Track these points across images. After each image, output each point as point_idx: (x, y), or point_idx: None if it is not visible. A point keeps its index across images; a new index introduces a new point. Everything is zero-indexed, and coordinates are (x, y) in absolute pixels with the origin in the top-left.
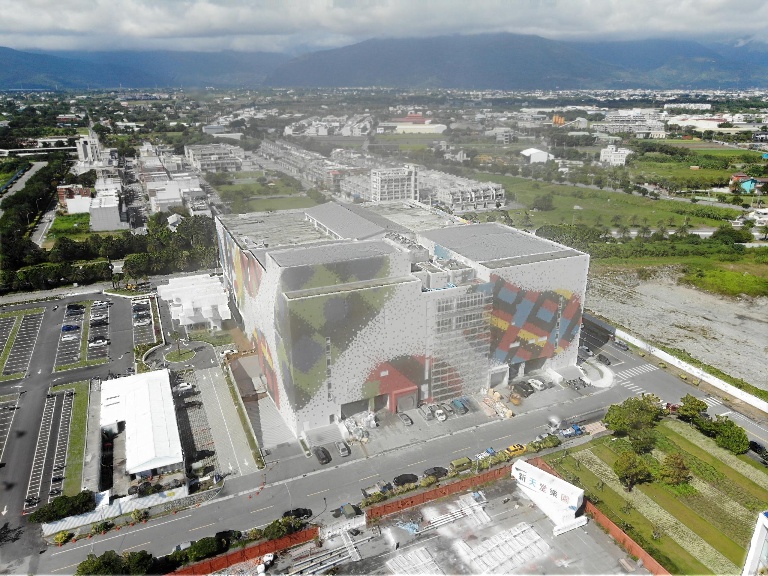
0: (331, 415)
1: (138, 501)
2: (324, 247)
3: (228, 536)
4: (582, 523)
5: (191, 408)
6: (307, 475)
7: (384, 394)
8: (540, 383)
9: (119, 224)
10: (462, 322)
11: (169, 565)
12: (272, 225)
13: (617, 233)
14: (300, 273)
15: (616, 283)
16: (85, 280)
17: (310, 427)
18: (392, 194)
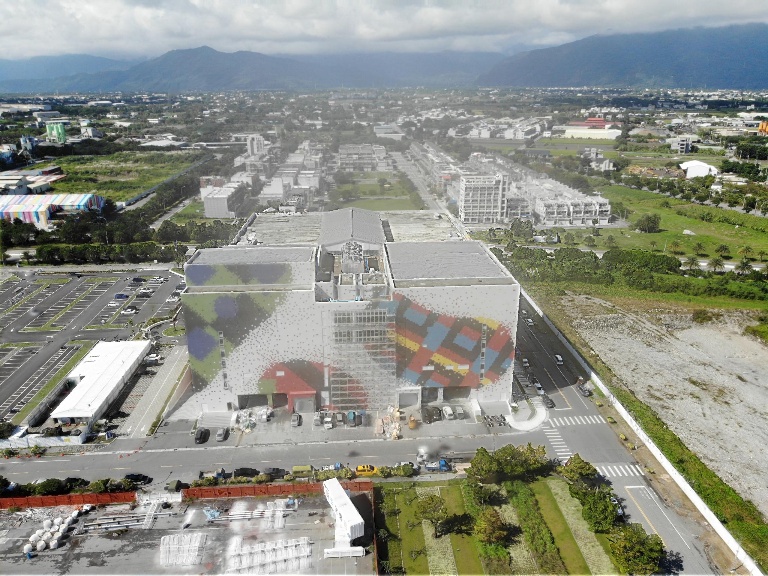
0: (229, 403)
1: (41, 439)
2: (251, 250)
3: (74, 482)
4: (358, 553)
5: (145, 376)
6: (177, 450)
7: (284, 393)
8: (449, 412)
9: (227, 213)
10: (363, 336)
11: (23, 493)
12: (290, 225)
13: (707, 266)
14: (203, 271)
15: (653, 322)
16: (164, 258)
17: (209, 410)
18: (477, 202)
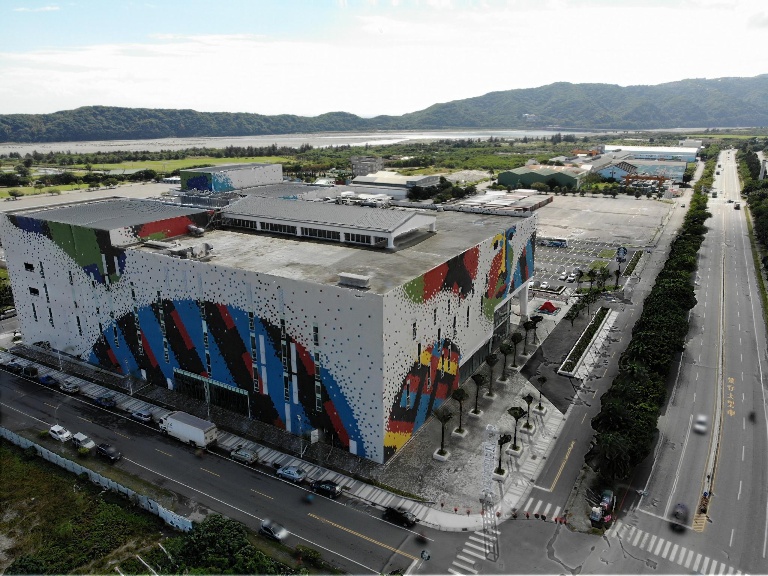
0: None
1: None
2: None
3: None
4: None
5: None
6: None
7: None
8: None
9: None
10: None
11: None
12: None
13: None
14: None
15: None
16: None
17: None
18: None
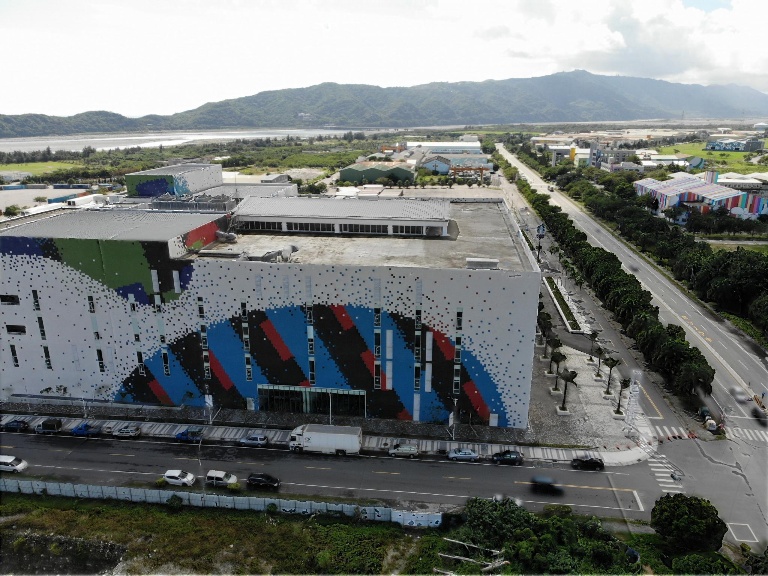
0: None
1: None
2: None
3: None
4: None
5: None
6: None
7: None
8: None
9: None
10: None
11: None
12: None
13: None
14: None
15: None
16: None
17: None
18: None
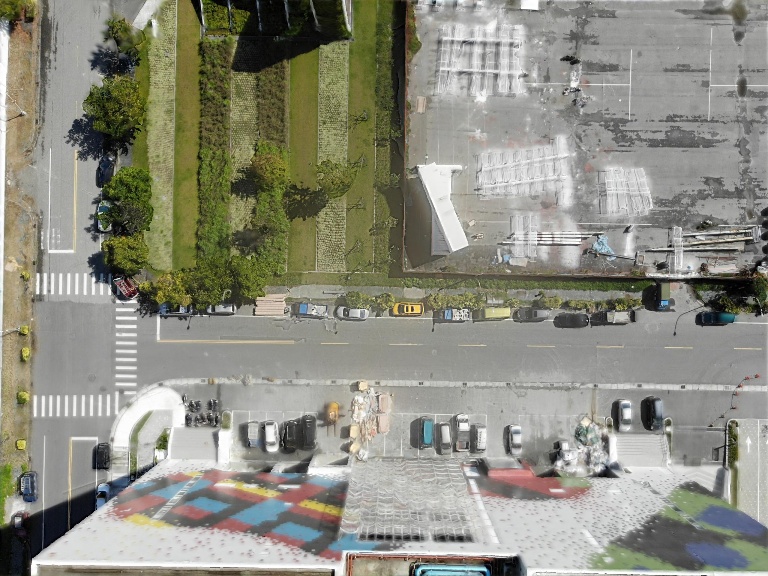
0: None
1: None
2: None
3: None
4: None
5: None
6: (681, 387)
7: None
8: (271, 429)
9: None
10: (411, 516)
11: None
12: None
13: None
14: None
15: None
16: None
17: (659, 470)
18: None
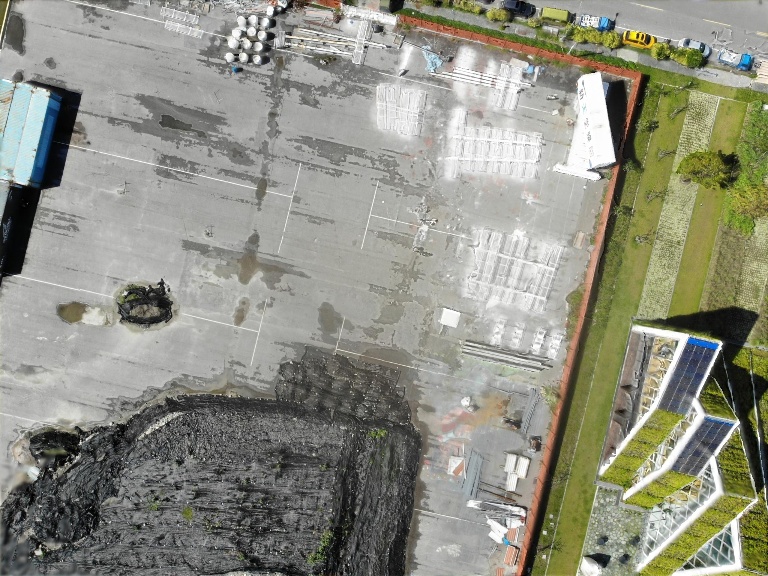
0: None
1: None
2: None
3: None
4: (591, 177)
5: None
6: None
7: None
8: None
9: None
10: None
11: None
12: None
13: None
14: None
15: None
16: None
17: None
18: None
